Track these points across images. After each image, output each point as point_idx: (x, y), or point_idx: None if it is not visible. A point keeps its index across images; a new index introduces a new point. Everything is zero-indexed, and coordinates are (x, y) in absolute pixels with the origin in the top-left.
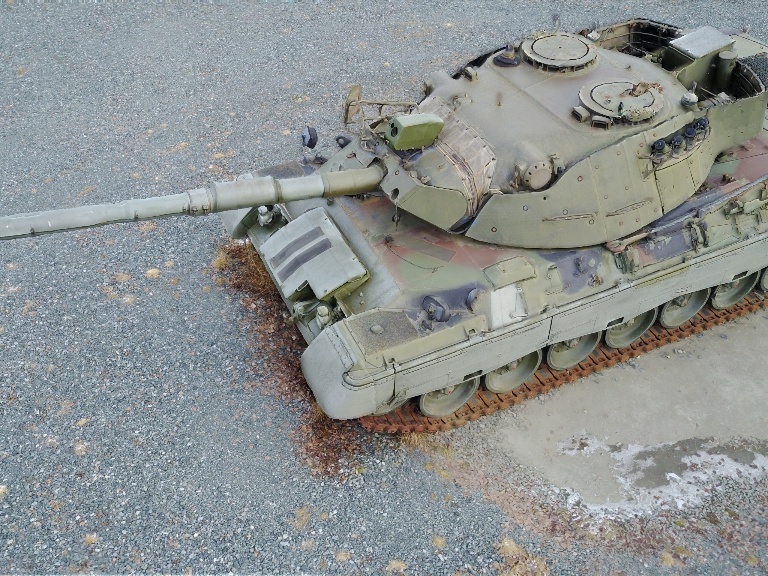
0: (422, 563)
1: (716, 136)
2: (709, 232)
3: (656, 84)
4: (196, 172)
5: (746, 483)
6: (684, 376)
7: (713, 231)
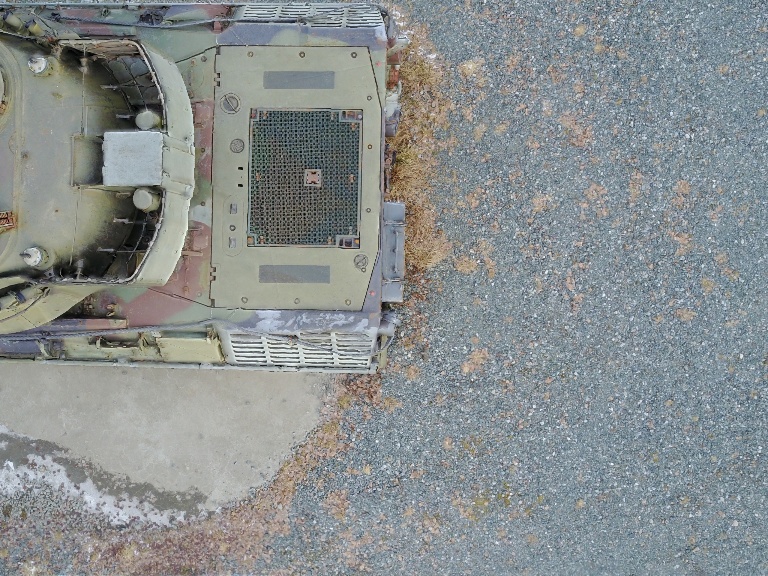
0: None
1: (78, 287)
2: (69, 347)
3: (8, 218)
4: None
5: (58, 497)
6: (94, 384)
7: (74, 347)
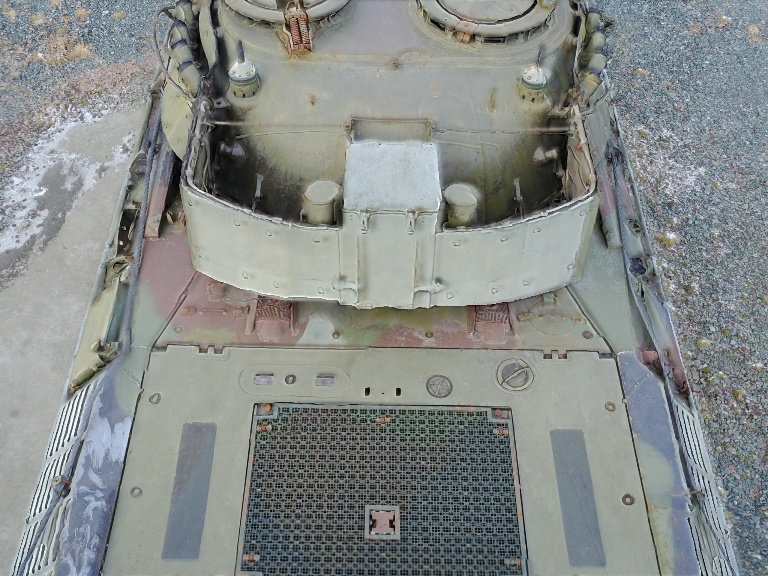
0: (111, 2)
1: None
2: None
3: (302, 43)
4: (717, 5)
5: None
6: None
7: None
